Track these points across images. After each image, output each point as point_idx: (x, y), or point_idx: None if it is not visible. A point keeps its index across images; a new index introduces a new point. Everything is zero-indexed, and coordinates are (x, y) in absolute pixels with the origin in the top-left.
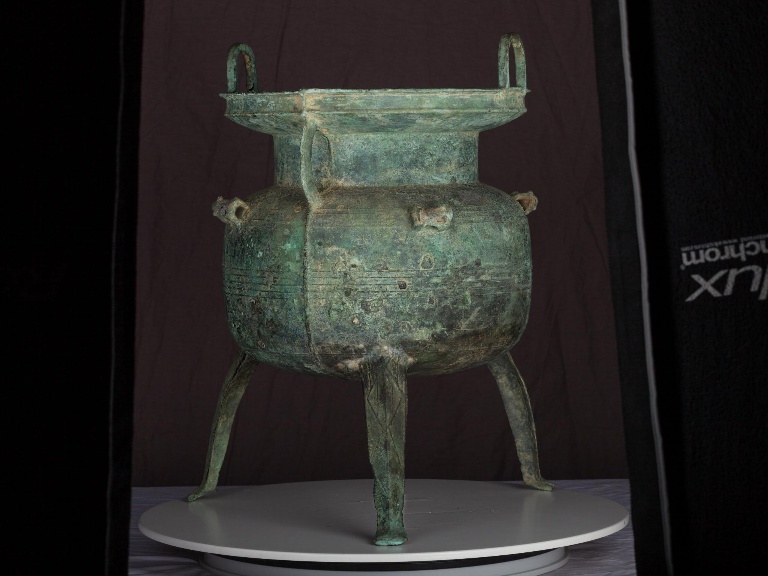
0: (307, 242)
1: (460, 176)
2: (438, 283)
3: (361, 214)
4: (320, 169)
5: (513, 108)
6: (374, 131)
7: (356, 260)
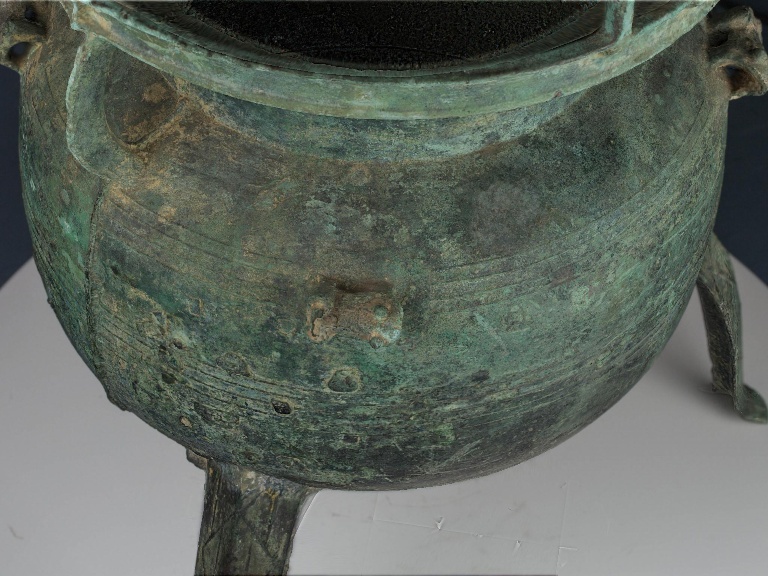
0: (91, 254)
1: (515, 123)
2: (368, 415)
3: (202, 253)
4: None
5: (651, 50)
6: None
7: (183, 336)
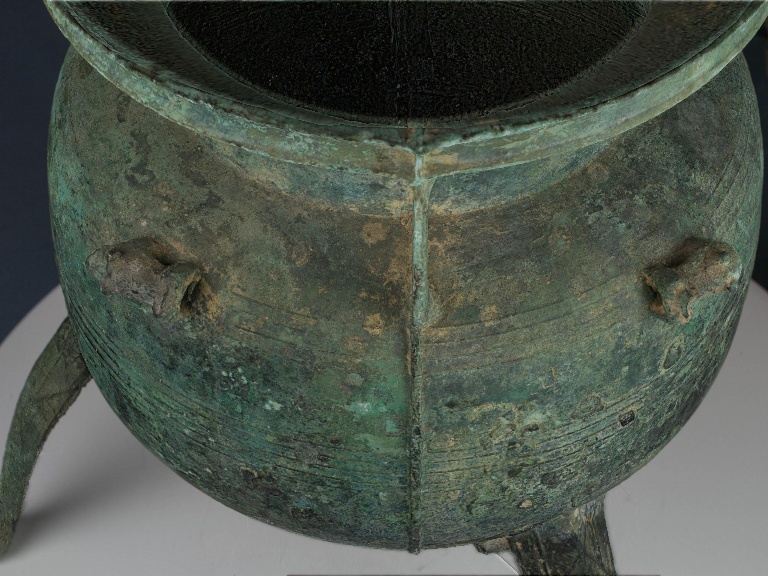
0: (420, 407)
1: None
2: (686, 373)
3: (544, 324)
4: (384, 183)
5: None
6: (542, 114)
7: (537, 416)
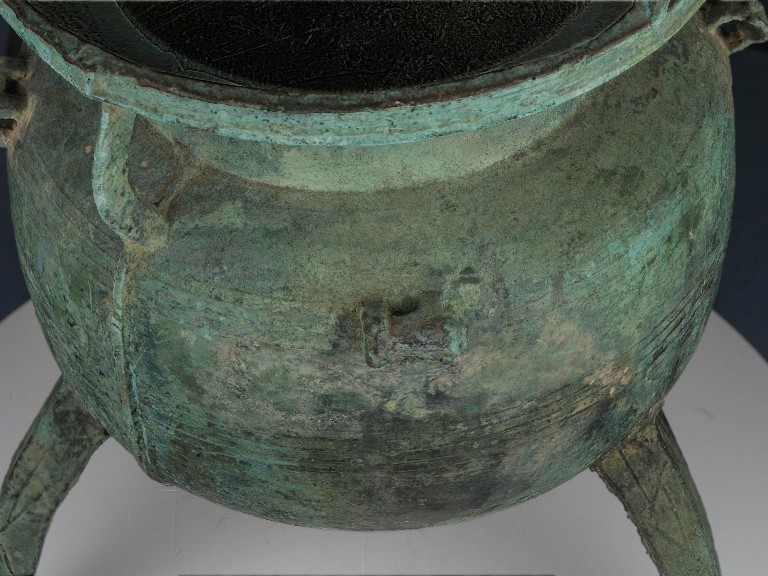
0: None
1: None
2: None
3: None
4: None
5: None
6: None
7: None
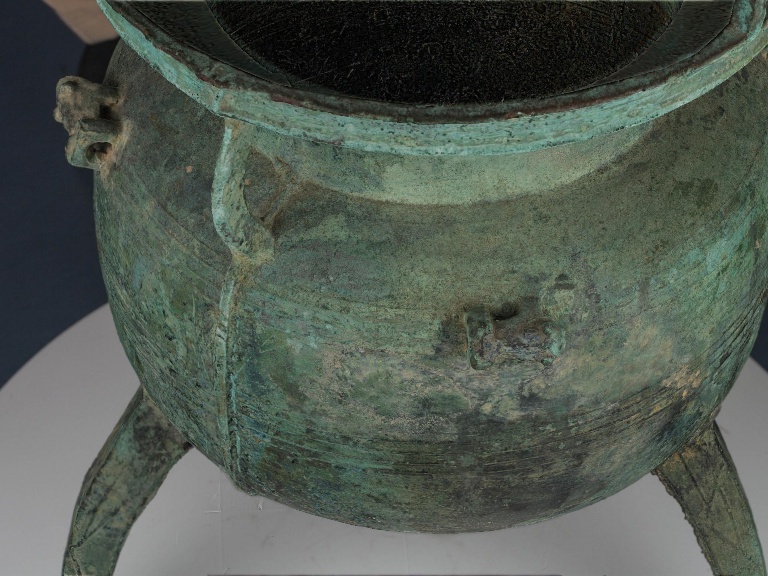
0: None
1: None
2: None
3: None
4: None
5: None
6: None
7: None
